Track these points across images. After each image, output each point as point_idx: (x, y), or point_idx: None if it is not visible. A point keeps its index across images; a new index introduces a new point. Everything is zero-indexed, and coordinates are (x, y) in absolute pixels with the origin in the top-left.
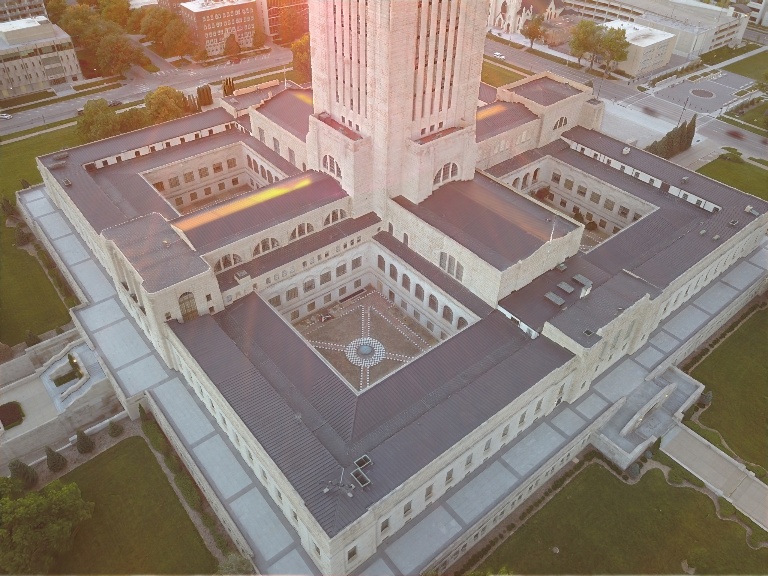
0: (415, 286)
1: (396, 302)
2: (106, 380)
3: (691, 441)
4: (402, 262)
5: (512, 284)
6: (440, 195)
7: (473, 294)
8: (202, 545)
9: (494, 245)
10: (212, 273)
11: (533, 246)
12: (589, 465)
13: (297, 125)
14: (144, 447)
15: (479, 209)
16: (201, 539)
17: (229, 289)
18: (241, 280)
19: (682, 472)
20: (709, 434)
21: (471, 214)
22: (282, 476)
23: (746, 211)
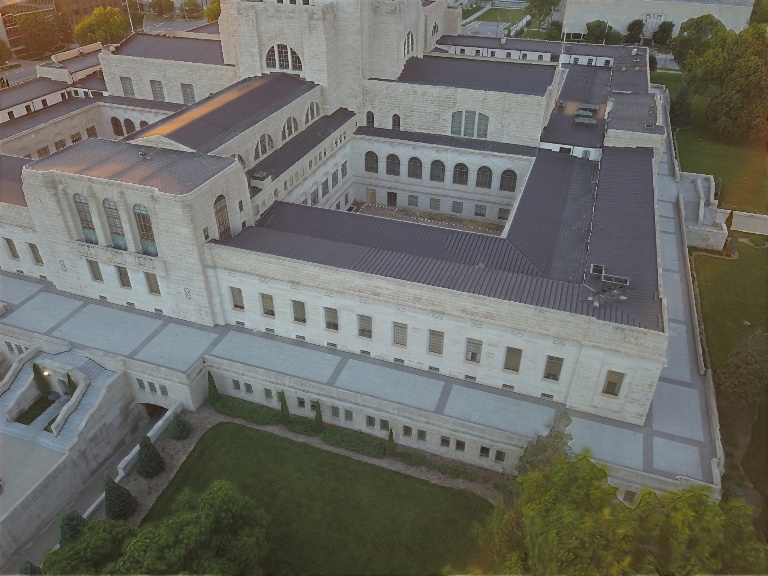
0: (430, 166)
1: (400, 203)
2: (122, 374)
3: (737, 218)
4: (408, 142)
5: (544, 118)
6: (413, 67)
7: (506, 144)
8: (433, 486)
9: (509, 86)
10: (241, 166)
11: (546, 76)
12: (695, 258)
13: (179, 58)
14: (242, 430)
15: (464, 66)
16: (425, 481)
17: (255, 195)
18: (264, 182)
19: (759, 236)
20: (744, 207)
21: (460, 72)
22: (542, 308)
23: (633, 54)
